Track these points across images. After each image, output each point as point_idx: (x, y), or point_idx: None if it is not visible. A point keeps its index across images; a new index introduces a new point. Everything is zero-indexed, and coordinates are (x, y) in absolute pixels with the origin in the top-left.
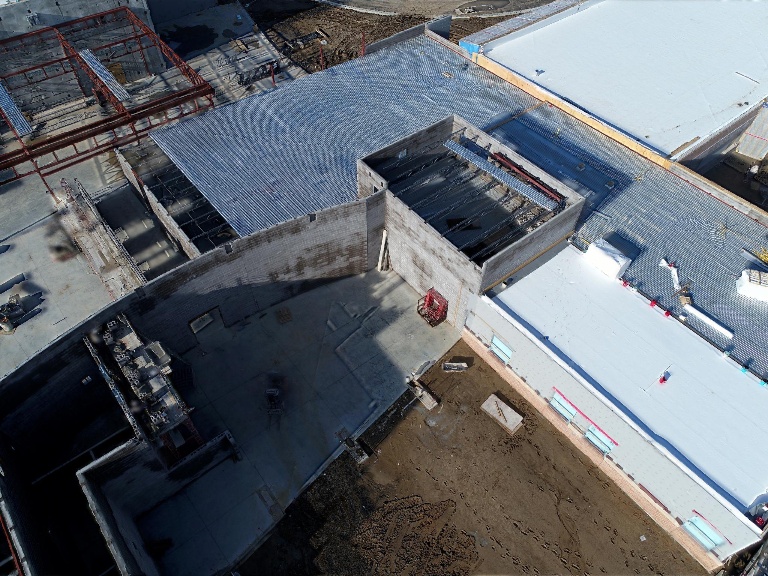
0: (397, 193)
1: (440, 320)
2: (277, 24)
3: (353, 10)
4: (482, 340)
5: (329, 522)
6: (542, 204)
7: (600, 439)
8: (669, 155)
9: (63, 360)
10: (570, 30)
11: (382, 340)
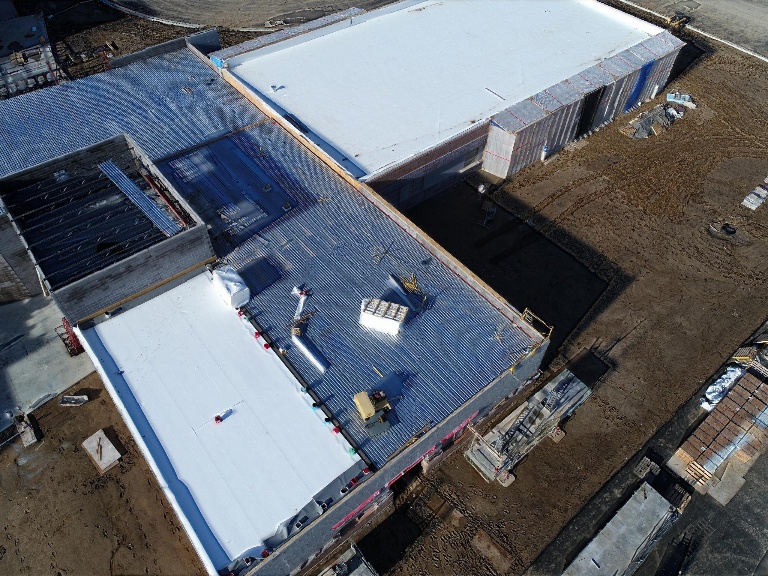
0: (15, 217)
1: (81, 349)
2: (71, 36)
3: (159, 22)
4: None
5: None
6: (163, 229)
7: None
8: None
9: None
10: (334, 44)
11: (11, 371)
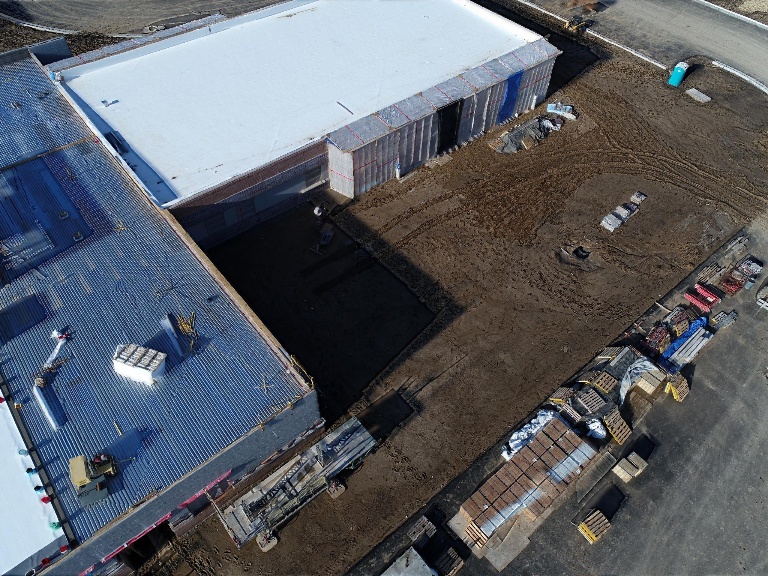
0: None
1: None
2: None
3: (31, 28)
4: None
5: None
6: None
7: None
8: None
9: None
10: (187, 54)
11: None
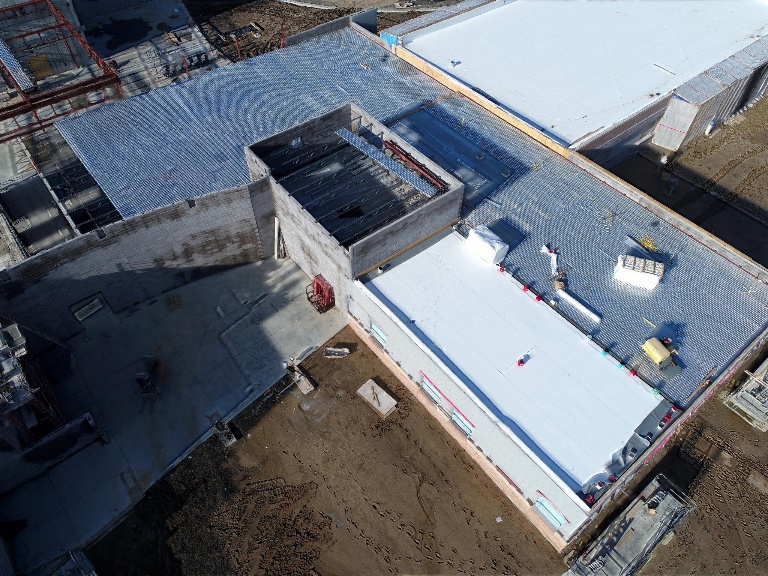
0: (279, 180)
1: (328, 307)
2: (213, 17)
3: (292, 4)
4: (363, 326)
5: (188, 504)
6: (422, 190)
7: (463, 422)
8: (571, 144)
9: None
10: (494, 22)
11: (268, 326)
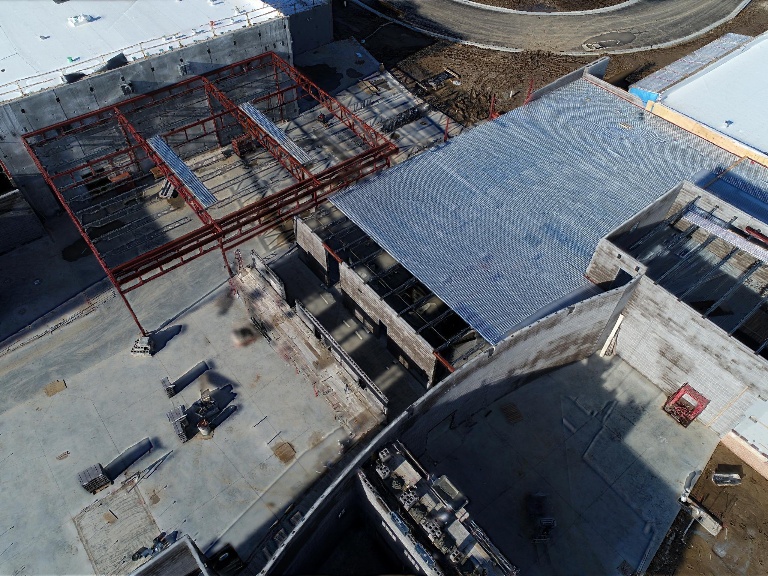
0: (658, 280)
1: (692, 419)
2: (400, 62)
3: (475, 46)
4: (759, 449)
5: None
6: None
7: None
8: None
9: (335, 499)
10: (741, 74)
11: (632, 444)
